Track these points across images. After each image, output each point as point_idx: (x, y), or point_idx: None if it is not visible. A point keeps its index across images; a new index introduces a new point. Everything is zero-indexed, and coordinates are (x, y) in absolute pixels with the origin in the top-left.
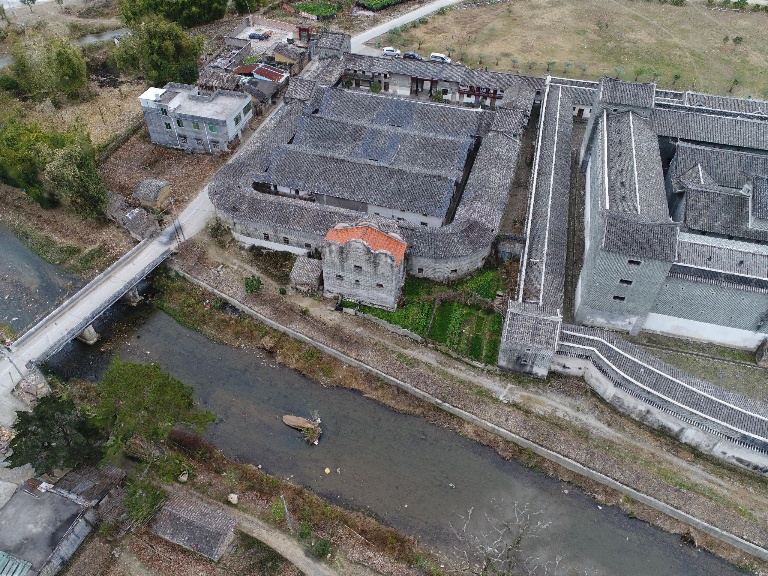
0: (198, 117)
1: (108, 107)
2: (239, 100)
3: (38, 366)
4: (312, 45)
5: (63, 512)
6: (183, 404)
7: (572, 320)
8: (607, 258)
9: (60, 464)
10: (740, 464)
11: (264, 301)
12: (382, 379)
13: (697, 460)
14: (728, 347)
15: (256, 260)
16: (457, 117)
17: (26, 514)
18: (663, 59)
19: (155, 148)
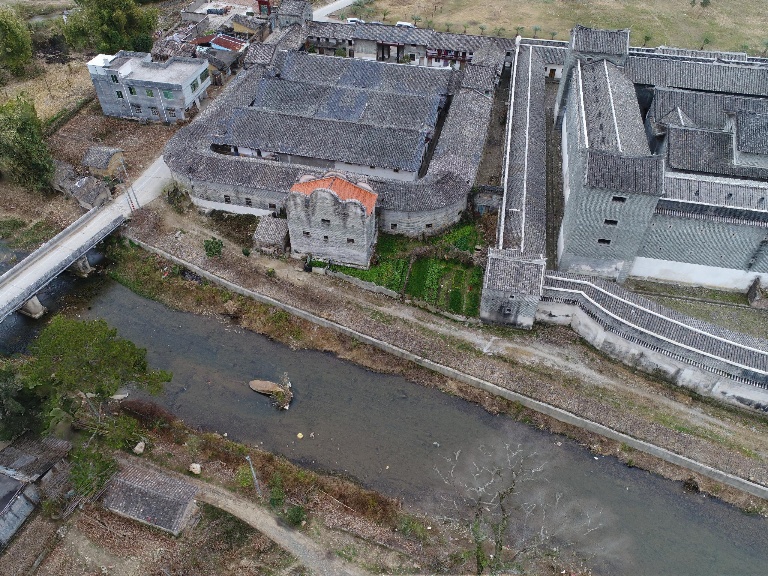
0: (151, 83)
1: (56, 82)
2: (195, 66)
3: None
4: (273, 16)
5: None
6: (133, 361)
7: (556, 270)
8: (590, 196)
9: None
10: (741, 404)
11: (226, 265)
12: (357, 339)
13: (695, 403)
14: (719, 290)
15: (217, 225)
16: (426, 76)
17: None
18: (632, 23)
19: (107, 119)
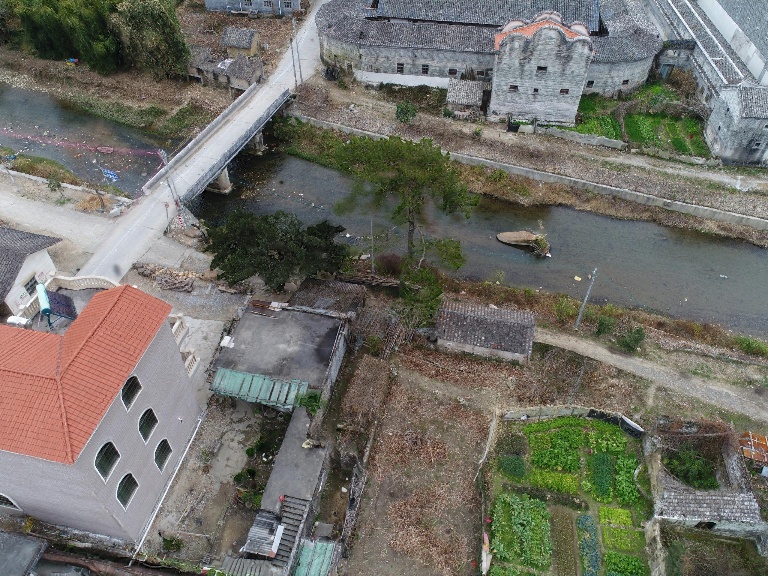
0: None
1: None
2: None
3: (186, 206)
4: None
5: (316, 327)
6: None
7: None
8: None
9: (296, 272)
10: None
11: (422, 130)
12: (590, 190)
13: None
14: None
15: (390, 97)
16: None
17: (269, 335)
18: None
19: (213, 14)
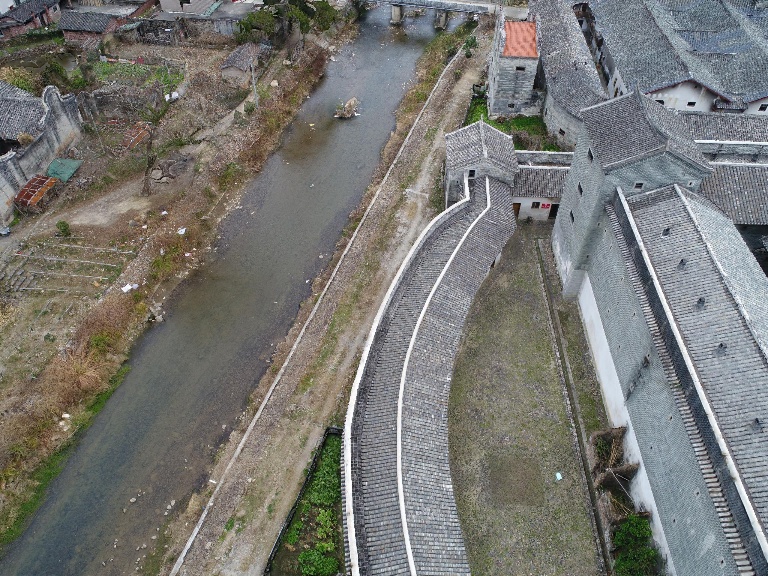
0: None
1: None
2: None
3: None
4: None
5: (242, 16)
6: None
7: None
8: None
9: None
10: None
11: None
12: None
13: None
14: (605, 409)
15: None
16: None
17: (240, 8)
18: None
19: None
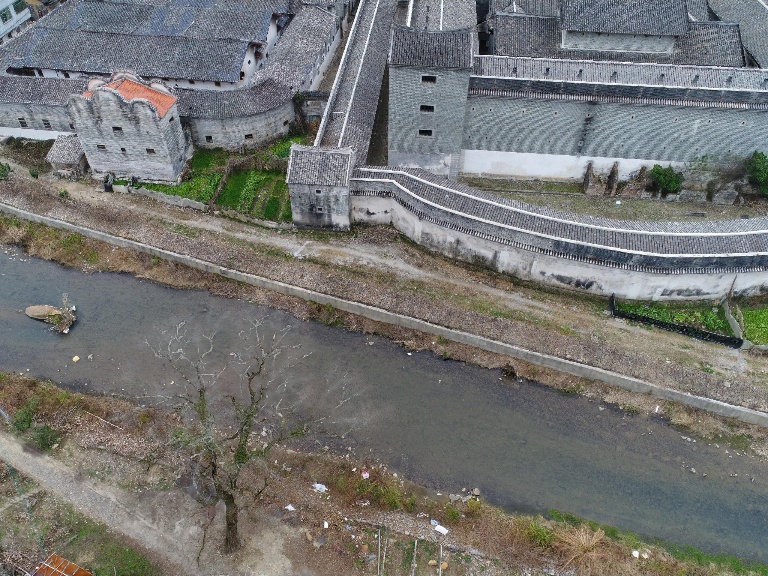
0: None
1: None
2: None
3: None
4: None
5: None
6: None
7: None
8: (399, 78)
9: None
10: (562, 284)
11: (16, 191)
12: (158, 256)
13: (517, 288)
14: (555, 182)
15: (14, 152)
16: None
17: None
18: None
19: None
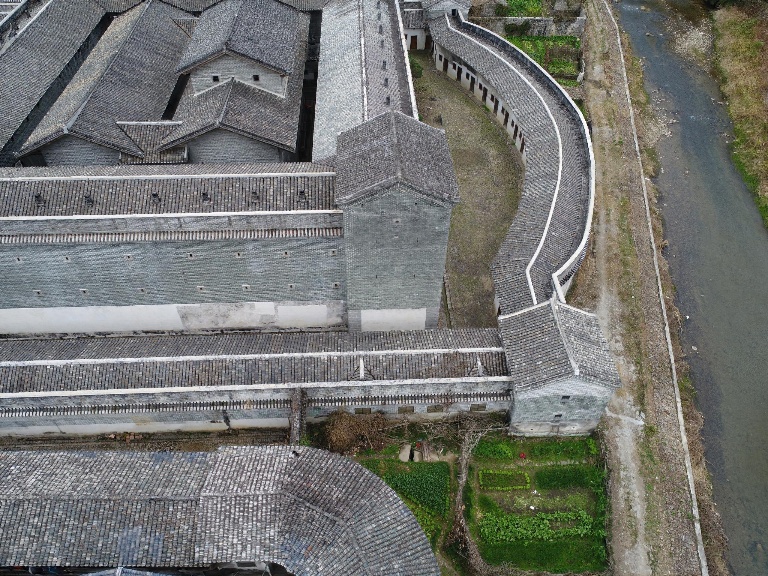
0: None
1: None
2: None
3: None
4: None
5: None
6: None
7: None
8: None
9: None
10: None
11: None
12: None
13: None
14: None
15: None
16: None
17: None
18: None
19: None
